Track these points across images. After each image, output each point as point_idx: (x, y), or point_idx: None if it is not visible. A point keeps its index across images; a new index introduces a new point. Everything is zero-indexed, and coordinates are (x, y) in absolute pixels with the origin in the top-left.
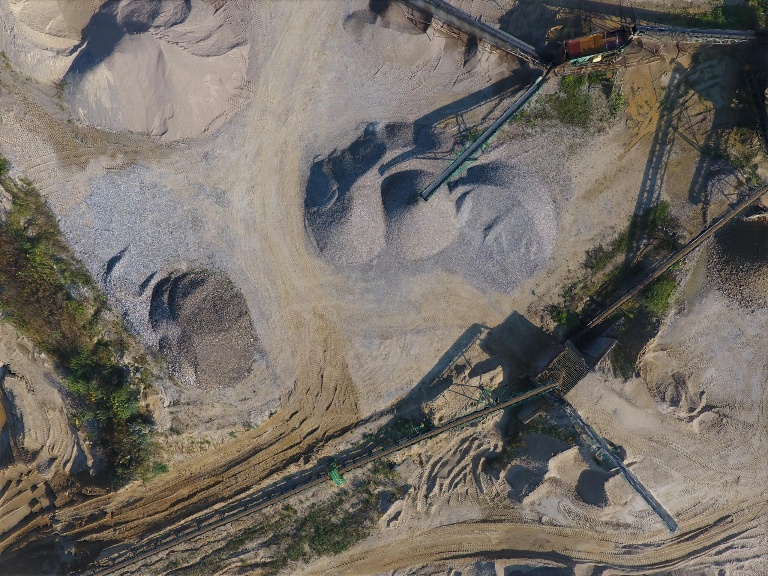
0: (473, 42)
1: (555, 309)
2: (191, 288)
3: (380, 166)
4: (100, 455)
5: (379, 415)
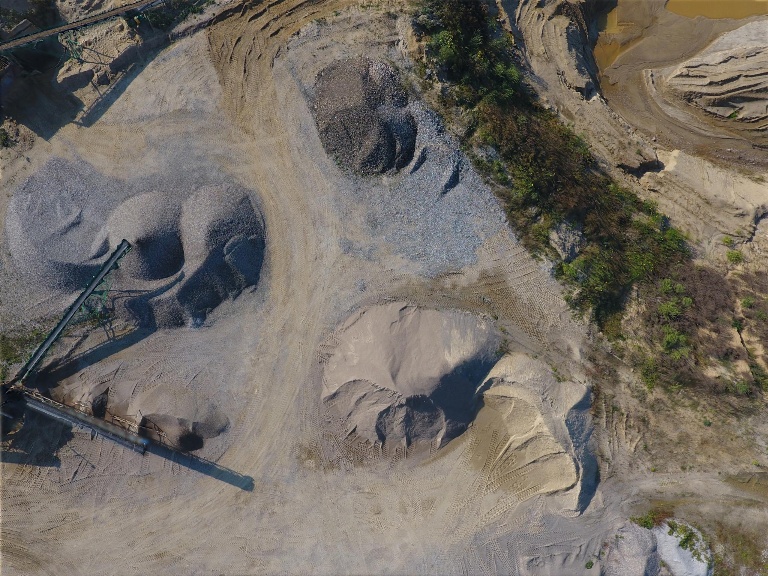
0: (98, 412)
1: (3, 143)
2: (374, 156)
3: (183, 280)
4: (484, 4)
5: (187, 33)
